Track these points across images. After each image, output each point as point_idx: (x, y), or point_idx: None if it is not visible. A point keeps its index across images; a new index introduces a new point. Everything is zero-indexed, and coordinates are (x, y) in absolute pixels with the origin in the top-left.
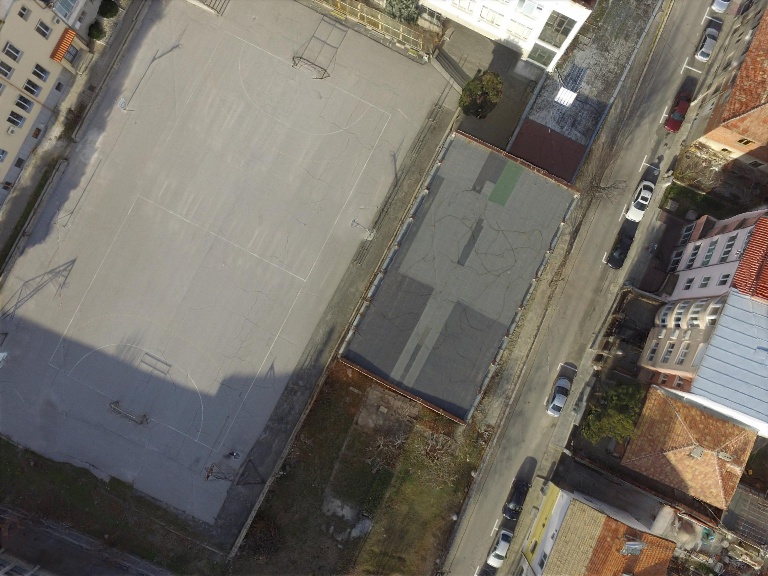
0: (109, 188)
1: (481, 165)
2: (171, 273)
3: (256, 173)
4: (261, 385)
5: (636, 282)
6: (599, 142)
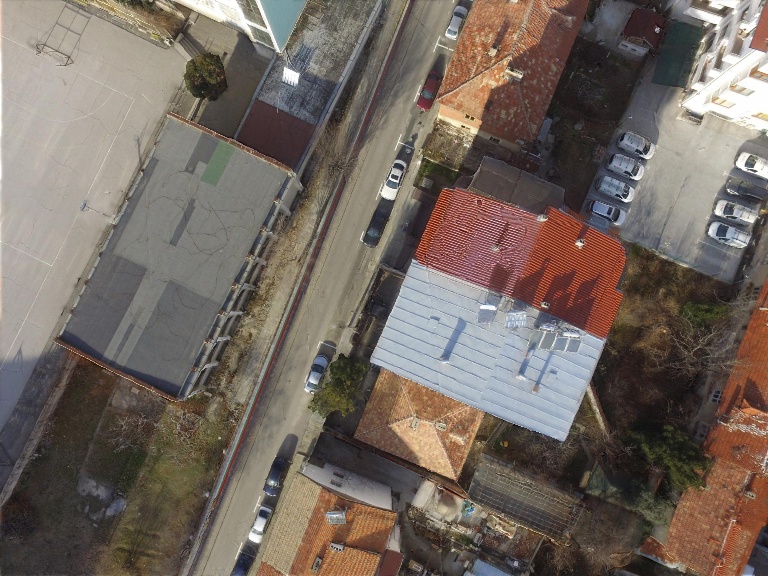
0: None
1: (193, 146)
2: None
3: (2, 161)
4: (9, 369)
5: (392, 260)
6: (346, 122)
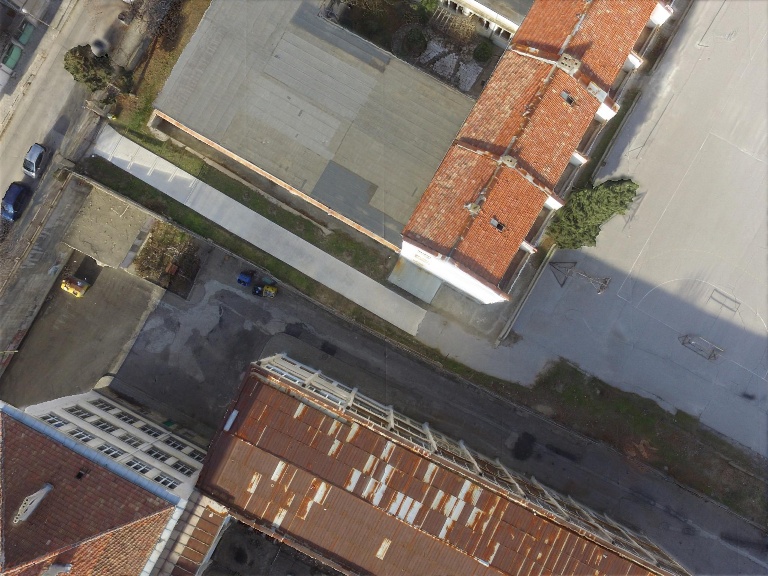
0: (681, 123)
1: None
2: (742, 211)
3: None
4: None
5: None
6: None
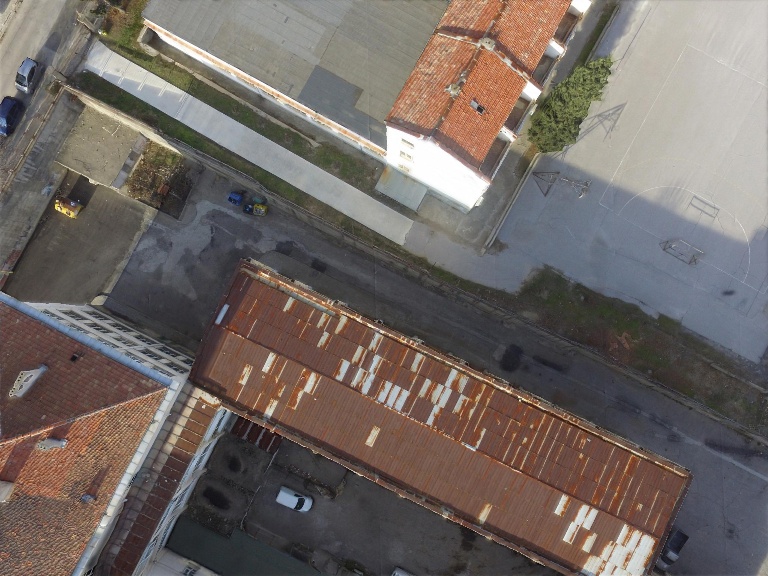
0: (658, 36)
1: None
2: (719, 120)
3: None
4: None
5: None
6: None
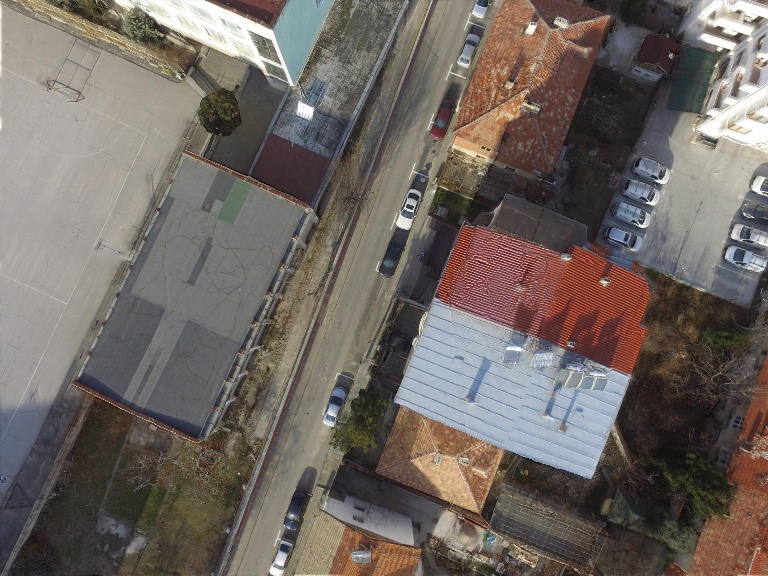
0: None
1: (210, 184)
2: None
3: (14, 199)
4: (26, 409)
5: (409, 290)
6: (360, 153)
